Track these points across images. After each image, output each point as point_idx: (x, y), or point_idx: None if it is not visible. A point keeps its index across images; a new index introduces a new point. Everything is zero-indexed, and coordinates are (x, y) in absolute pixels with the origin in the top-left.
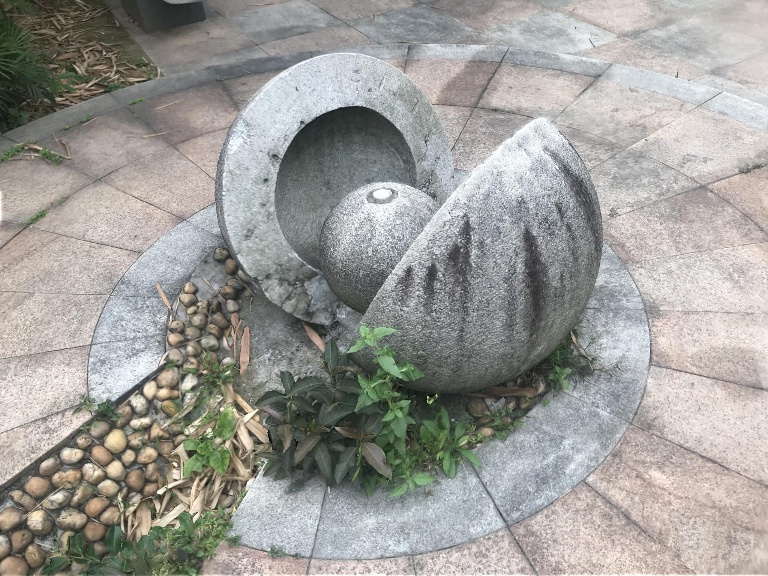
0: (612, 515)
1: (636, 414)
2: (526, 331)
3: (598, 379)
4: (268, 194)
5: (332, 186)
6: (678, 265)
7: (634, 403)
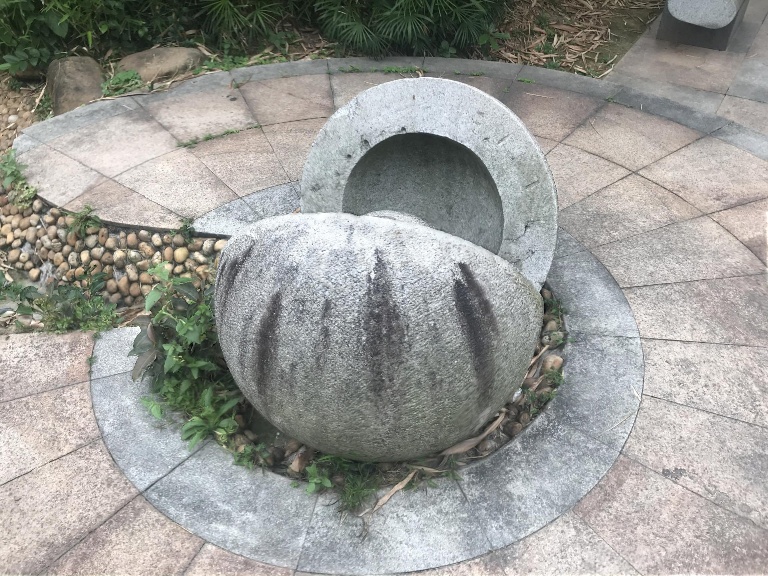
0: (170, 575)
1: (311, 573)
2: (254, 383)
3: (349, 525)
4: (346, 168)
5: (453, 213)
6: (614, 575)
7: (327, 568)
